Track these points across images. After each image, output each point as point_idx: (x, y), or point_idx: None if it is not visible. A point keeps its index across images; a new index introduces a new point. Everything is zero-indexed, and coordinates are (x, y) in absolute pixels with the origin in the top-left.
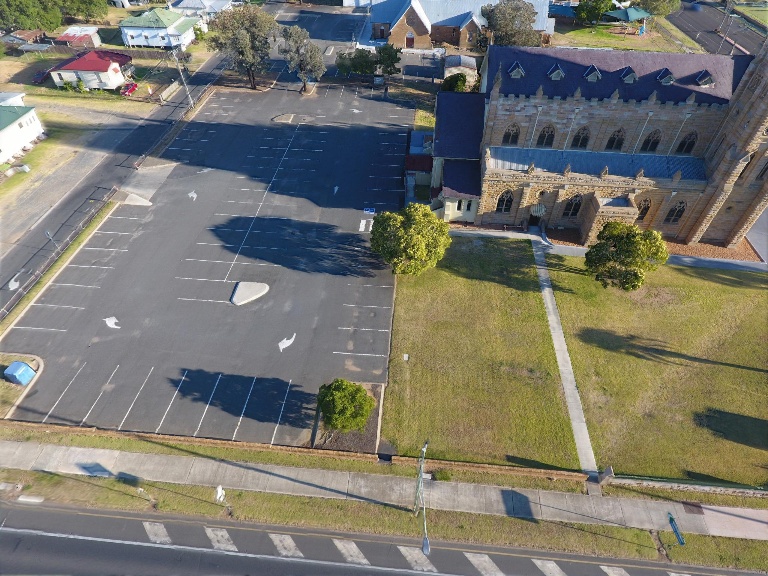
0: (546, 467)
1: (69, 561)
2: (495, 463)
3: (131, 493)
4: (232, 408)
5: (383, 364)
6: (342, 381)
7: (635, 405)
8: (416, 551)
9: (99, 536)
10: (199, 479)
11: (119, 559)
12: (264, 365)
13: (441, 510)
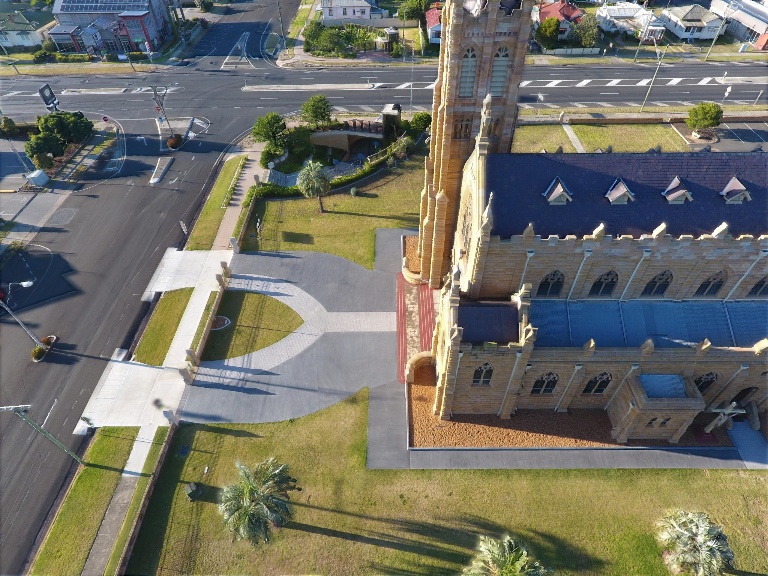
0: None
1: (763, 96)
2: (612, 125)
3: (766, 107)
4: (761, 131)
5: None
6: (715, 109)
7: (542, 146)
8: (634, 105)
9: (761, 101)
10: (743, 112)
11: (745, 97)
12: (767, 146)
13: (630, 113)
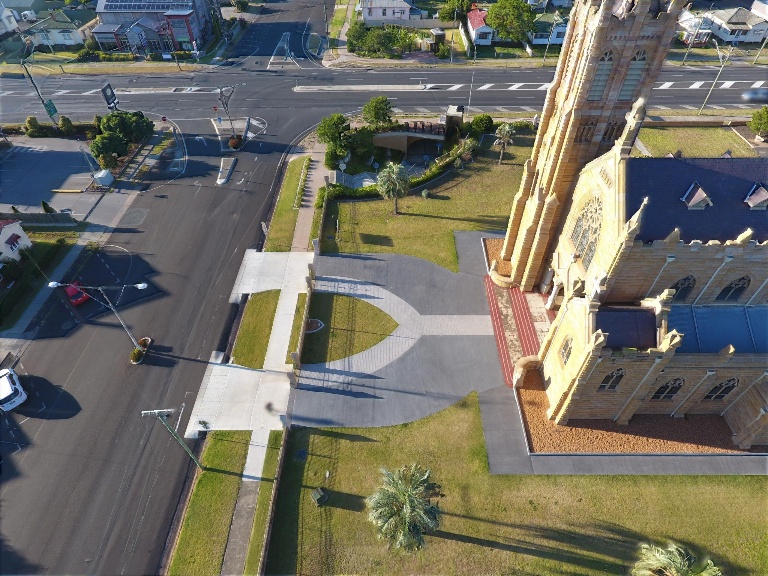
0: (648, 127)
1: None
2: (672, 127)
3: None
4: None
5: (763, 155)
6: None
7: None
8: (691, 108)
9: None
10: None
11: None
12: None
13: (688, 116)
